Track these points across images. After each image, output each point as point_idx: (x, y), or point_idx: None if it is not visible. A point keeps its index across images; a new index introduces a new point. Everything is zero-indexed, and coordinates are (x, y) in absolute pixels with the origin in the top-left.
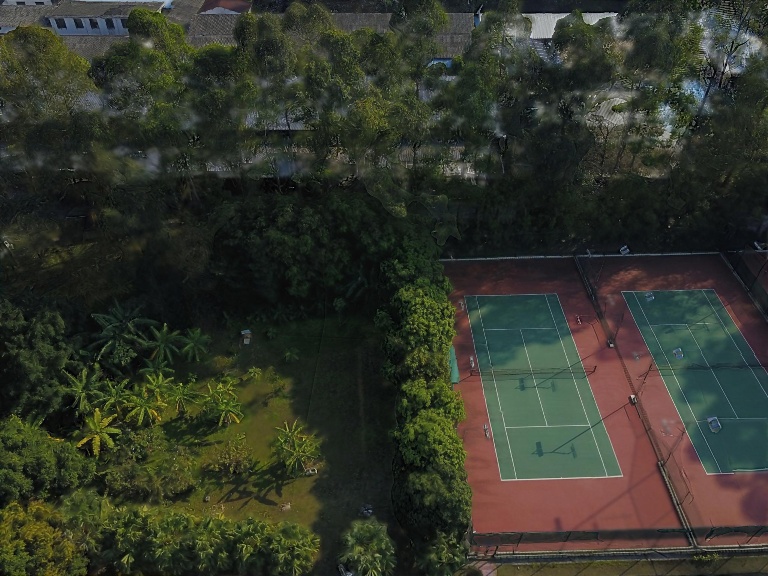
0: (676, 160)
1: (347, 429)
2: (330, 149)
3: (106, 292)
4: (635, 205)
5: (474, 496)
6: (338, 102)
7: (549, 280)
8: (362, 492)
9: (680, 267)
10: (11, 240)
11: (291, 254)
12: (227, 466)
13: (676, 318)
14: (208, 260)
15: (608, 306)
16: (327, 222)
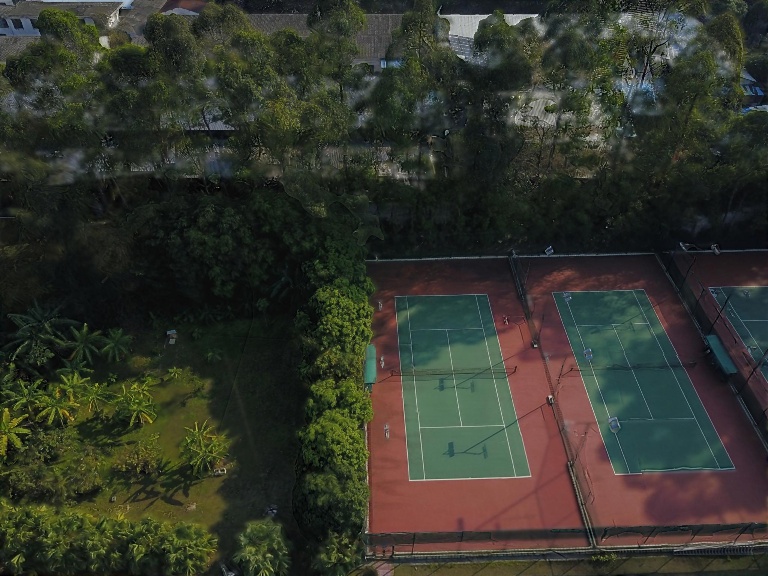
0: (606, 161)
1: (262, 429)
2: (252, 149)
3: (25, 292)
4: (567, 206)
5: (380, 496)
6: (249, 102)
7: (481, 280)
8: (269, 492)
9: (613, 268)
10: None
11: (212, 254)
12: (134, 466)
13: (603, 318)
14: (127, 260)
15: (537, 306)
16: (249, 222)
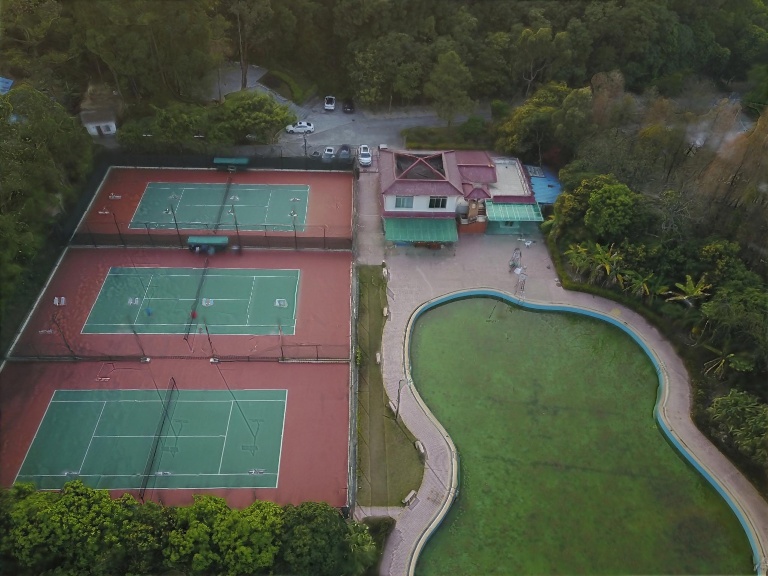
0: None
1: None
2: None
3: None
4: None
5: None
6: None
7: (31, 392)
8: None
9: (71, 280)
10: None
11: None
12: None
13: None
14: None
15: (96, 349)
16: None
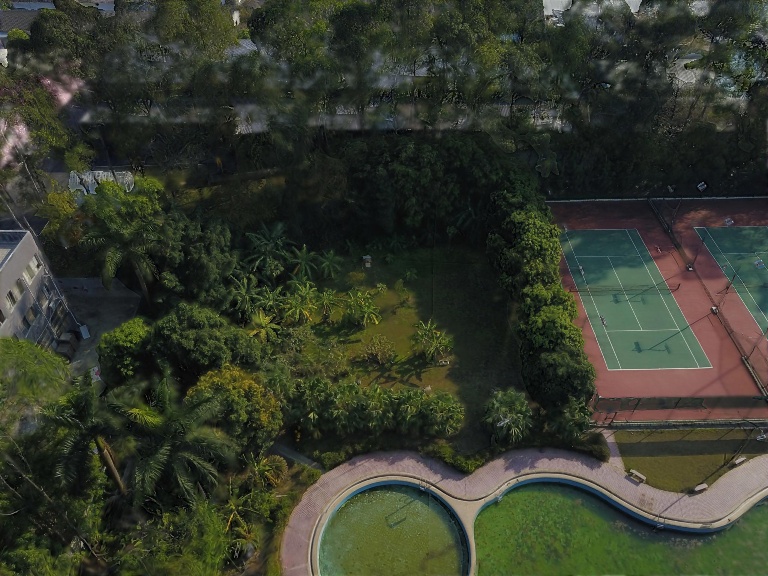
0: (744, 110)
1: (469, 332)
2: (446, 94)
3: (255, 216)
4: (705, 151)
5: None
6: (467, 47)
7: (628, 218)
8: (490, 378)
9: (744, 208)
10: (182, 167)
11: (413, 185)
12: (375, 355)
13: (745, 248)
14: (344, 188)
15: (683, 239)
16: (443, 158)
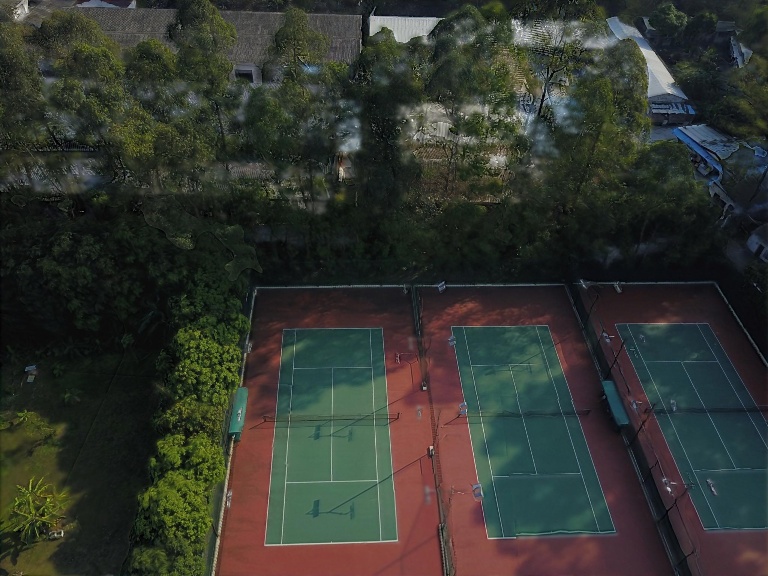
0: (509, 188)
1: (112, 484)
2: (116, 172)
3: None
4: (471, 234)
5: (229, 564)
6: (94, 125)
7: (378, 312)
8: (107, 559)
9: (520, 300)
10: None
11: (70, 287)
12: None
13: (501, 358)
14: None
15: (433, 343)
16: (112, 252)
